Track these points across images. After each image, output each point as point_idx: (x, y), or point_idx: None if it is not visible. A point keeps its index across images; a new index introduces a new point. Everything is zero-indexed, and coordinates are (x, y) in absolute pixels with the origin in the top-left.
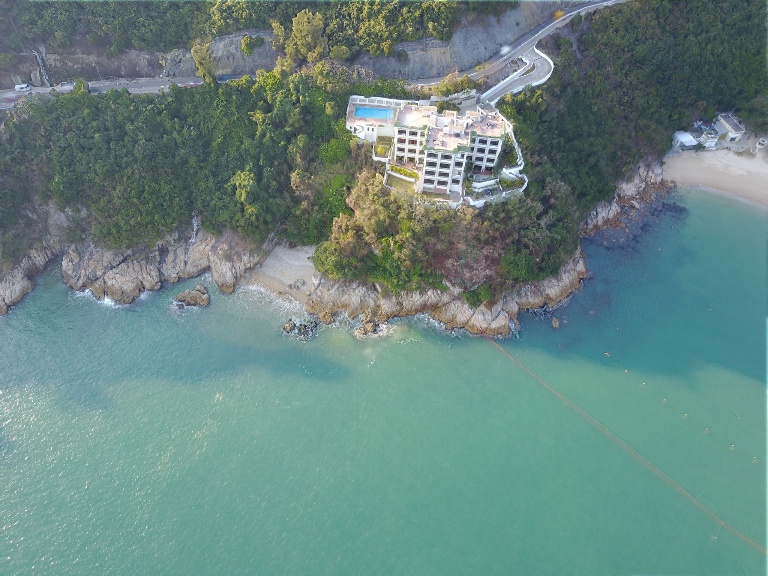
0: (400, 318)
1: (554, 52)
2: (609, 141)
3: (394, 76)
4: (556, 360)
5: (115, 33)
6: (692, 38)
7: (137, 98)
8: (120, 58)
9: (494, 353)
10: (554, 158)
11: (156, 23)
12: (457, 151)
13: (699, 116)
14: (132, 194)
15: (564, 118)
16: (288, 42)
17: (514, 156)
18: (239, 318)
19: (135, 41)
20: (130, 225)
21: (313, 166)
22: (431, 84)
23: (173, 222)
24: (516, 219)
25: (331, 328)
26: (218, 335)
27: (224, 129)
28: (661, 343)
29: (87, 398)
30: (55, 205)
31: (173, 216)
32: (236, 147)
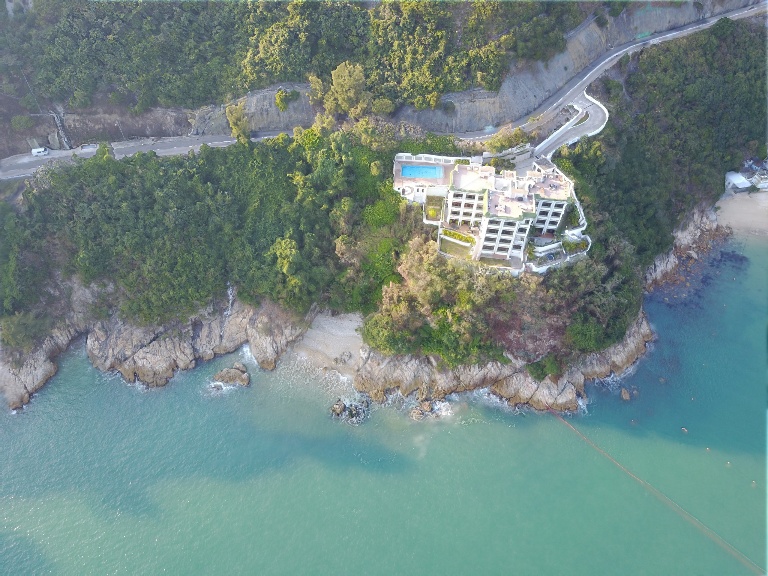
0: (458, 394)
1: (604, 96)
2: (664, 189)
3: (440, 129)
4: (631, 438)
5: (139, 90)
6: (741, 75)
7: (166, 161)
8: (145, 117)
9: (563, 431)
10: (613, 212)
11: (183, 78)
12: (522, 218)
13: (751, 156)
14: (164, 267)
15: (619, 168)
16: (327, 97)
17: (576, 216)
18: (283, 399)
19: (161, 99)
20: (162, 300)
21: (357, 229)
22: (481, 137)
23: (208, 295)
24: (583, 286)
25: (384, 408)
26: (262, 420)
27: (260, 192)
28: (741, 414)
29: (123, 501)
30: (79, 280)
31: (208, 288)
32: (274, 211)
